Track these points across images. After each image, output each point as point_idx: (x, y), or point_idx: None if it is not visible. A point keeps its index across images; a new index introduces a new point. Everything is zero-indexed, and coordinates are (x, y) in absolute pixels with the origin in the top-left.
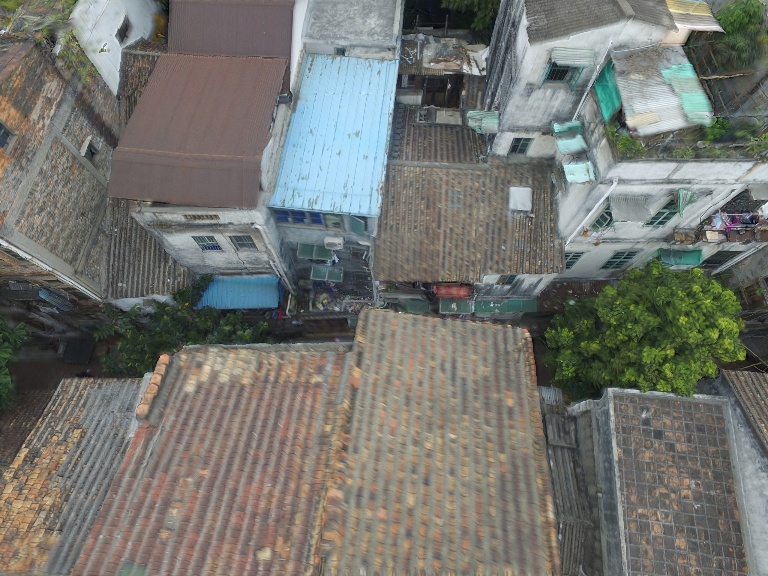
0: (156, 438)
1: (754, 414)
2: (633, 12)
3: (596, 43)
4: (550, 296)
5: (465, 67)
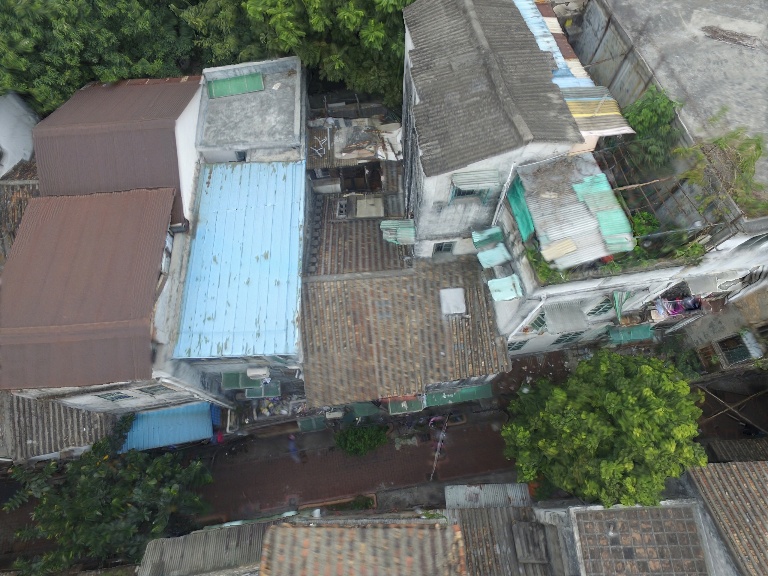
0: None
1: (725, 522)
2: (531, 135)
3: (498, 164)
4: (504, 376)
5: (380, 152)
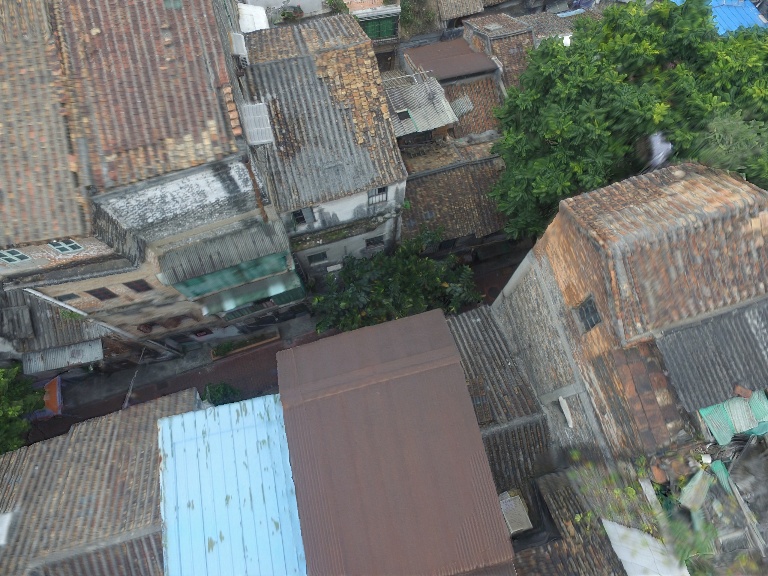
0: (211, 81)
1: None
2: None
3: None
4: None
5: None
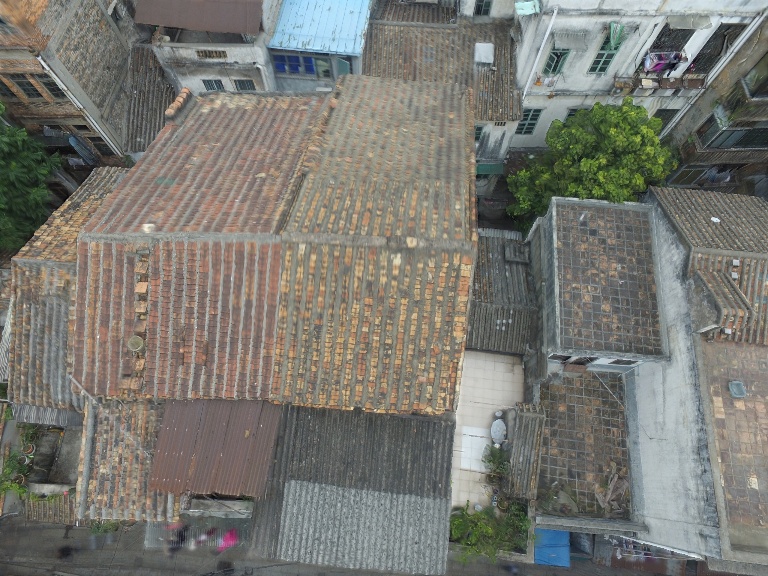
0: (180, 130)
1: (671, 209)
2: None
3: None
4: (516, 164)
5: None
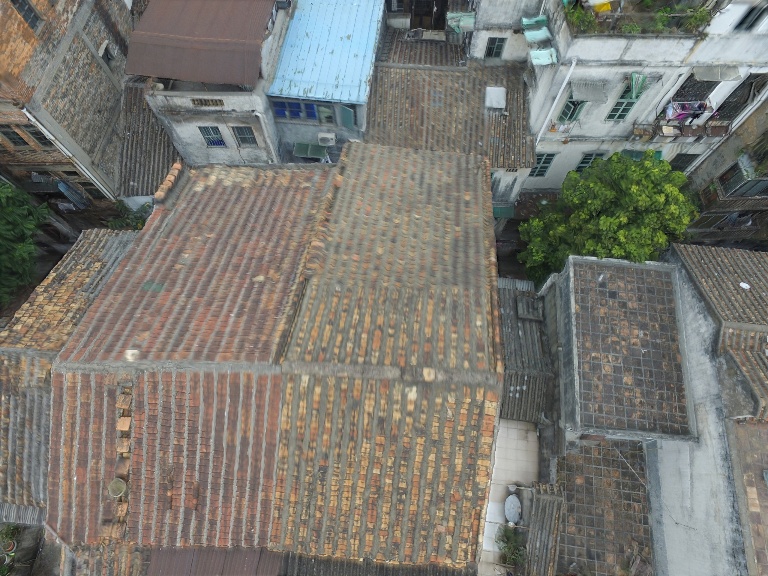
0: (170, 216)
1: (696, 272)
2: None
3: None
4: (526, 205)
5: None
